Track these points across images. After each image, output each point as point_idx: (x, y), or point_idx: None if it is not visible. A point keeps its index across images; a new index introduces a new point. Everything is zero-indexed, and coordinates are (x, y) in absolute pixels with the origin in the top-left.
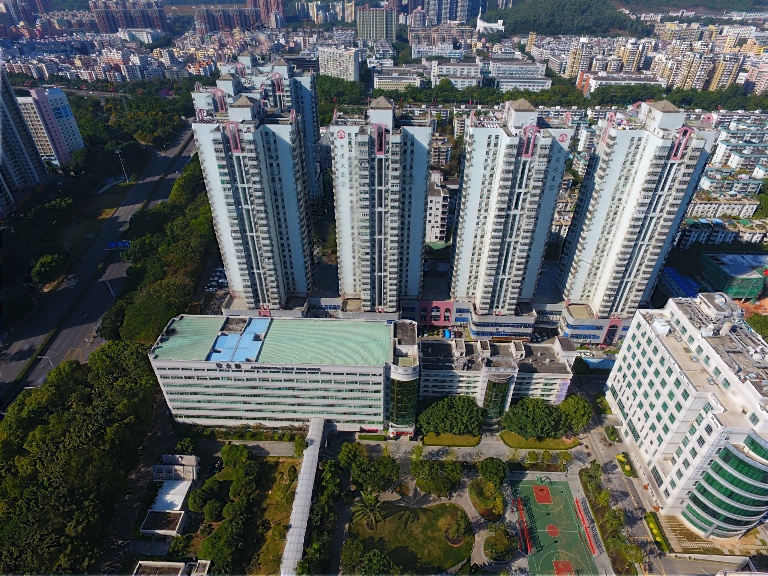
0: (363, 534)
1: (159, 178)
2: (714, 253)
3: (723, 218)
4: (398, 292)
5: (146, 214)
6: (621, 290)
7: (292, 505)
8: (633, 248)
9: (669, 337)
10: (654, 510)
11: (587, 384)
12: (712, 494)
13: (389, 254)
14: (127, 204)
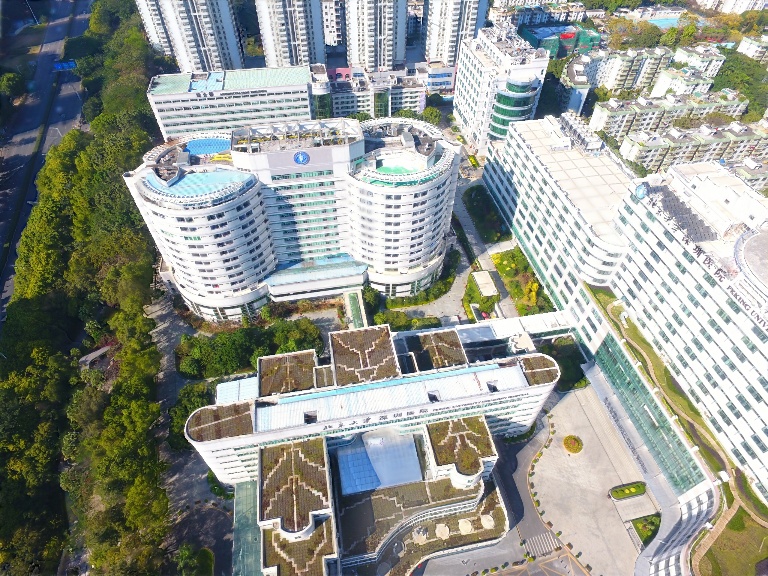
0: None
1: (69, 18)
2: (531, 27)
3: (542, 5)
4: None
5: (79, 39)
6: (459, 42)
7: None
8: (461, 5)
9: (477, 51)
10: (474, 155)
11: (443, 110)
12: (496, 127)
13: (299, 24)
14: (49, 41)
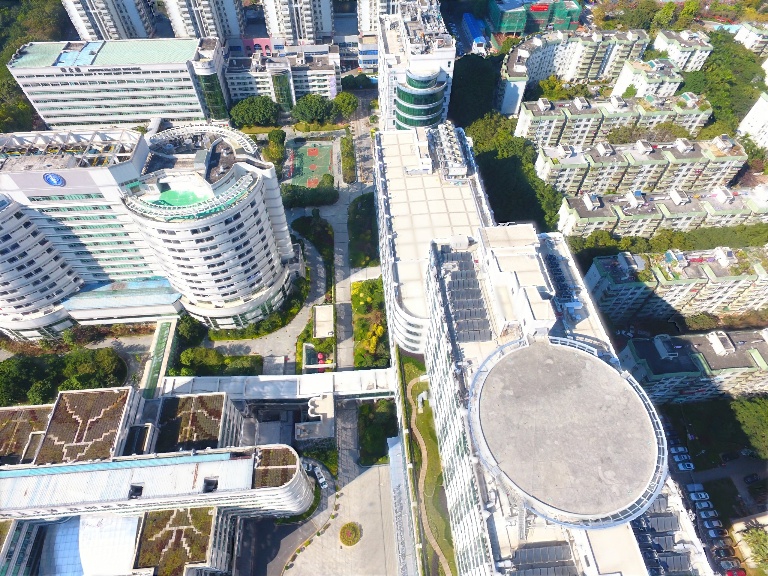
0: None
1: None
2: None
3: None
4: (223, 32)
5: None
6: None
7: None
8: None
9: (392, 30)
10: None
11: (369, 94)
12: (400, 125)
13: None
14: None
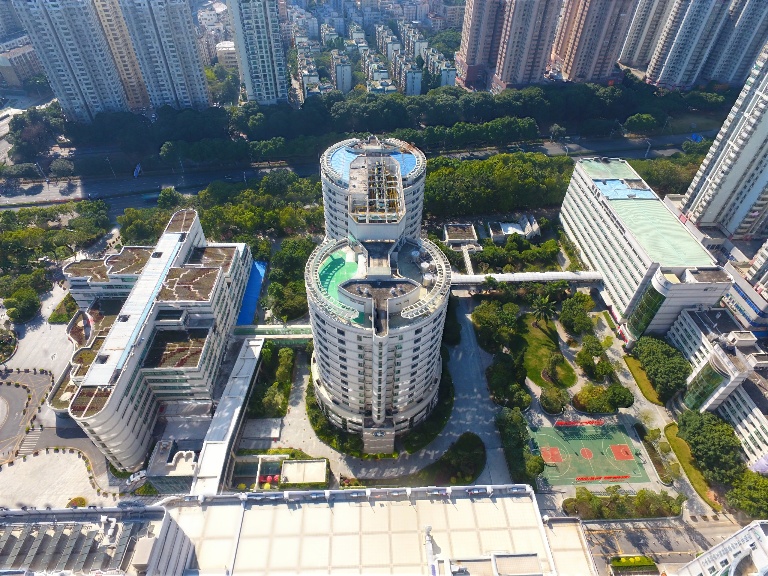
0: (527, 321)
1: None
2: None
3: None
4: None
5: None
6: None
7: (527, 272)
8: None
9: None
10: (662, 572)
11: None
12: None
13: None
14: None
